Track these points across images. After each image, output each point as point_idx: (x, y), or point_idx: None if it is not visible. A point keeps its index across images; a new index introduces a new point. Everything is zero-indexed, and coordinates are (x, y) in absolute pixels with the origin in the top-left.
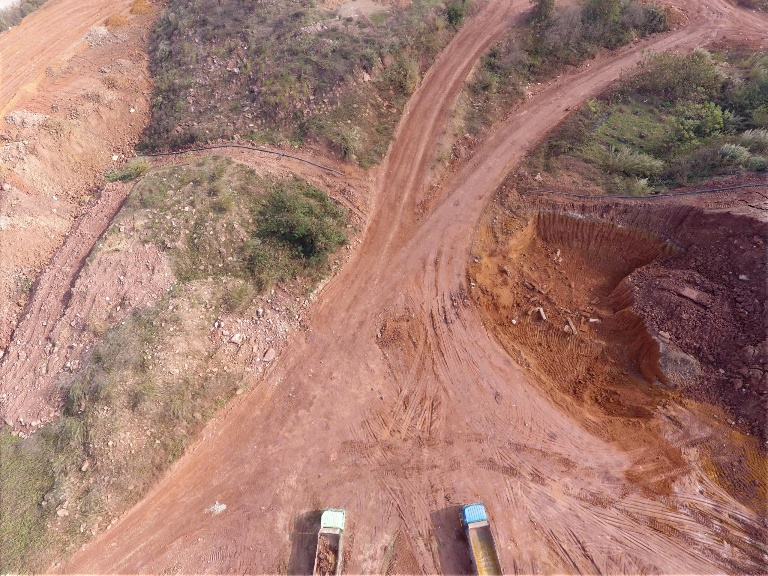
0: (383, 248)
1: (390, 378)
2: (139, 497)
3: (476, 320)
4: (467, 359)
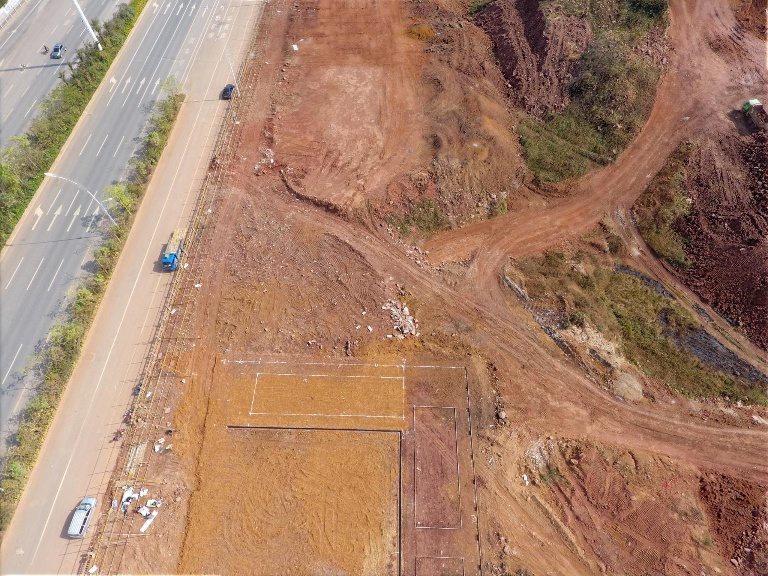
0: (684, 12)
1: (729, 64)
2: (646, 119)
3: (754, 37)
4: (760, 52)
